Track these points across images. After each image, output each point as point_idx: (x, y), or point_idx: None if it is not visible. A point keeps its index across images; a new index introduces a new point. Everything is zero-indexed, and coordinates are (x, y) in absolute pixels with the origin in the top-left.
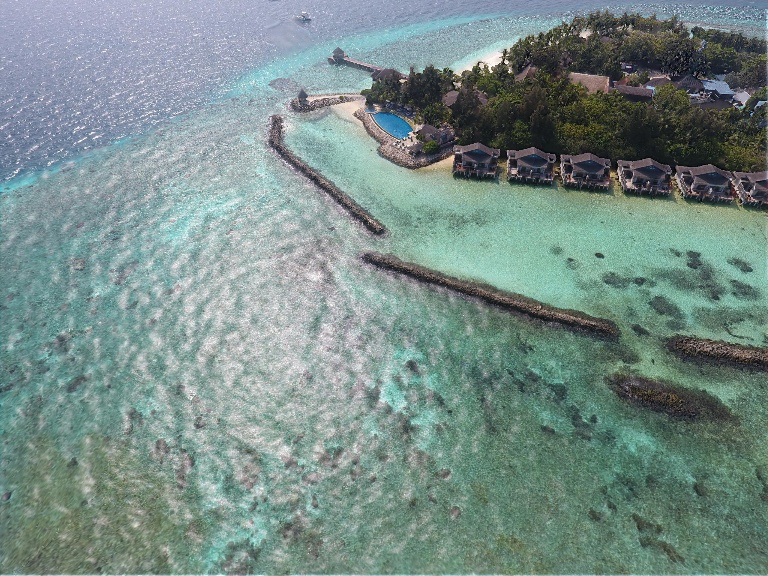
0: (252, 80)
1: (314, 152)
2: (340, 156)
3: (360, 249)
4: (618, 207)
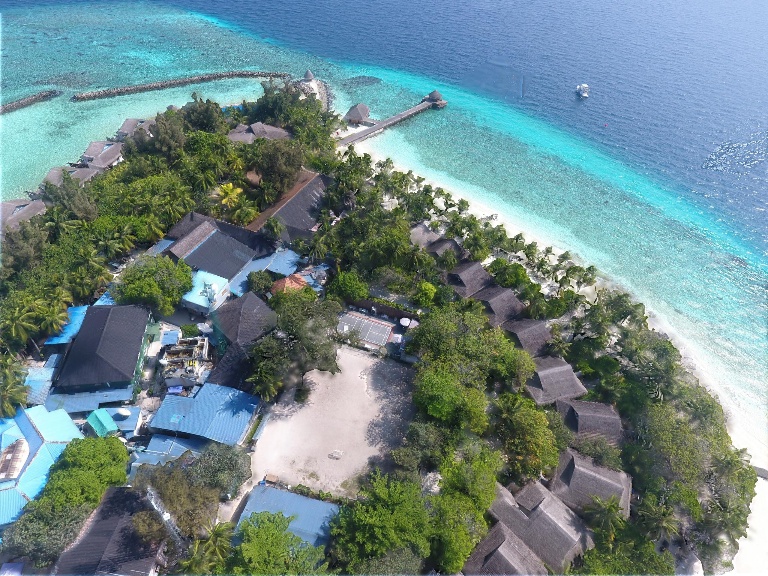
0: (369, 68)
1: (215, 86)
2: (202, 94)
3: (66, 93)
4: (1, 201)
